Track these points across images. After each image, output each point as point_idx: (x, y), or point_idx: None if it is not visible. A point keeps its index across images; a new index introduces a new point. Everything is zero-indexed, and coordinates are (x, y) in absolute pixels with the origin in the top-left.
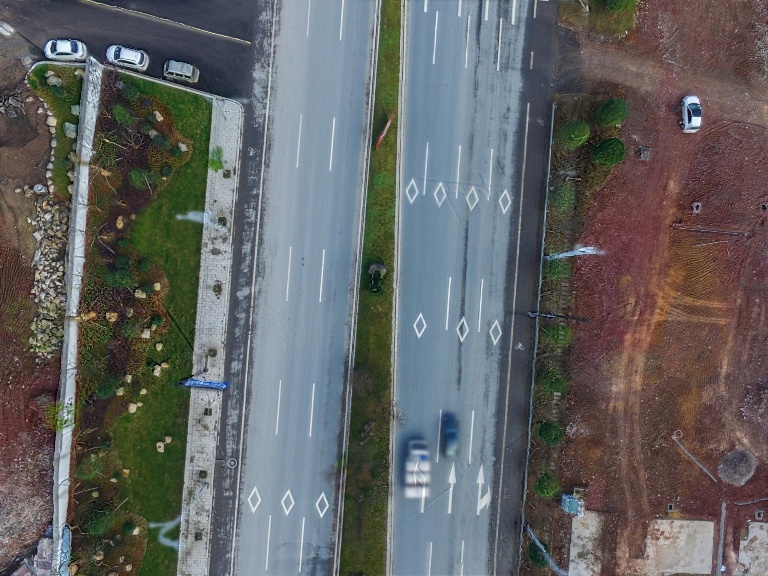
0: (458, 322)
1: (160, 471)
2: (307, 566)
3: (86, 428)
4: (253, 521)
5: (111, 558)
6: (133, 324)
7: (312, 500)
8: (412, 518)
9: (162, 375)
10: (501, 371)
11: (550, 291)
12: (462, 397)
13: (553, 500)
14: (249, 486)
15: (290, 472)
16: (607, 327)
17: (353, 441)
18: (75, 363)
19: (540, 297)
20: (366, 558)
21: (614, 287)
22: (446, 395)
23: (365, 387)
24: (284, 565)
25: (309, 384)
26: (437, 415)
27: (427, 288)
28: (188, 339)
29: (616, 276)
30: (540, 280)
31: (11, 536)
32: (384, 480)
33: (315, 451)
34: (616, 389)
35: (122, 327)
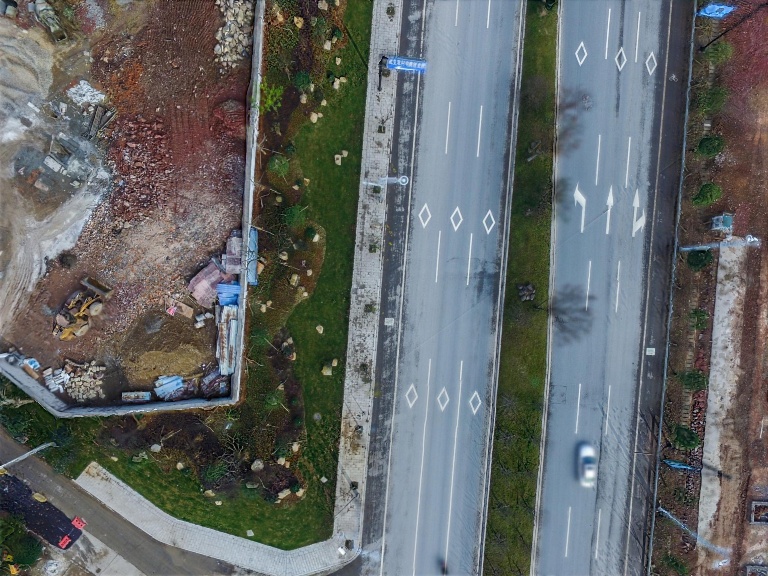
0: (617, 52)
1: (337, 184)
2: (474, 280)
3: (270, 134)
4: (424, 236)
5: (294, 260)
6: (318, 31)
7: (479, 217)
8: (572, 237)
9: (340, 90)
10: (656, 100)
11: (702, 26)
12: (620, 124)
13: (702, 225)
14: (420, 202)
15: (458, 190)
16: (754, 62)
17: (520, 159)
18: (260, 71)
19: (694, 29)
20: (532, 269)
21: (761, 25)
22: (605, 121)
23: (532, 107)
24: (453, 278)
25: (477, 106)
26: (596, 140)
27: (588, 18)
28: (363, 58)
29: (763, 14)
30: (695, 12)
31: (196, 241)
32: (548, 198)
33: (482, 171)
34: (761, 122)
35: (307, 35)
